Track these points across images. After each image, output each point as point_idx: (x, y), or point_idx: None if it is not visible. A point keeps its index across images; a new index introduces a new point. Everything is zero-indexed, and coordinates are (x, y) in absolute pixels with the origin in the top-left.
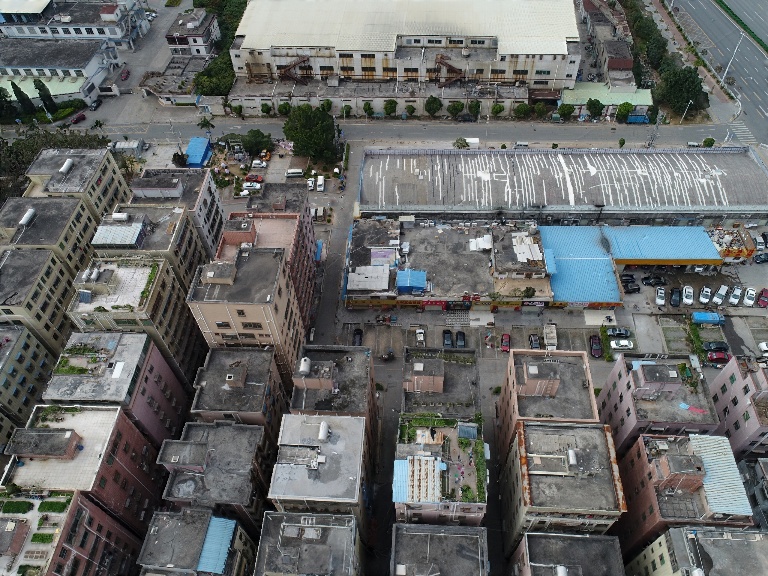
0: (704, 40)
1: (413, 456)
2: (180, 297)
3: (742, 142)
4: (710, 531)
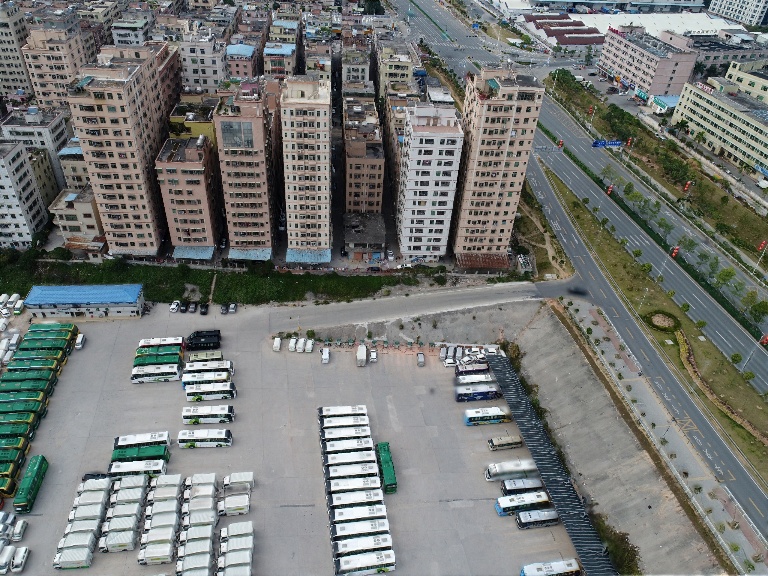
0: (396, 5)
1: (249, 5)
2: (179, 8)
3: (394, 22)
4: (318, 15)
